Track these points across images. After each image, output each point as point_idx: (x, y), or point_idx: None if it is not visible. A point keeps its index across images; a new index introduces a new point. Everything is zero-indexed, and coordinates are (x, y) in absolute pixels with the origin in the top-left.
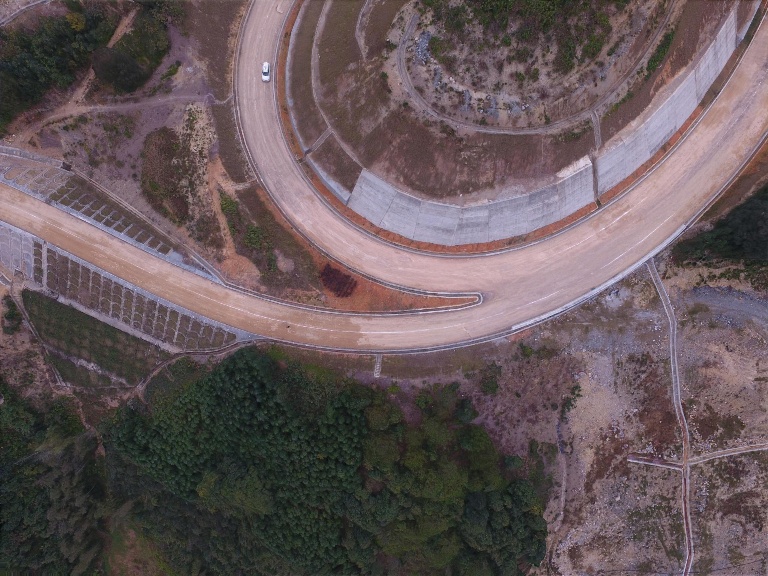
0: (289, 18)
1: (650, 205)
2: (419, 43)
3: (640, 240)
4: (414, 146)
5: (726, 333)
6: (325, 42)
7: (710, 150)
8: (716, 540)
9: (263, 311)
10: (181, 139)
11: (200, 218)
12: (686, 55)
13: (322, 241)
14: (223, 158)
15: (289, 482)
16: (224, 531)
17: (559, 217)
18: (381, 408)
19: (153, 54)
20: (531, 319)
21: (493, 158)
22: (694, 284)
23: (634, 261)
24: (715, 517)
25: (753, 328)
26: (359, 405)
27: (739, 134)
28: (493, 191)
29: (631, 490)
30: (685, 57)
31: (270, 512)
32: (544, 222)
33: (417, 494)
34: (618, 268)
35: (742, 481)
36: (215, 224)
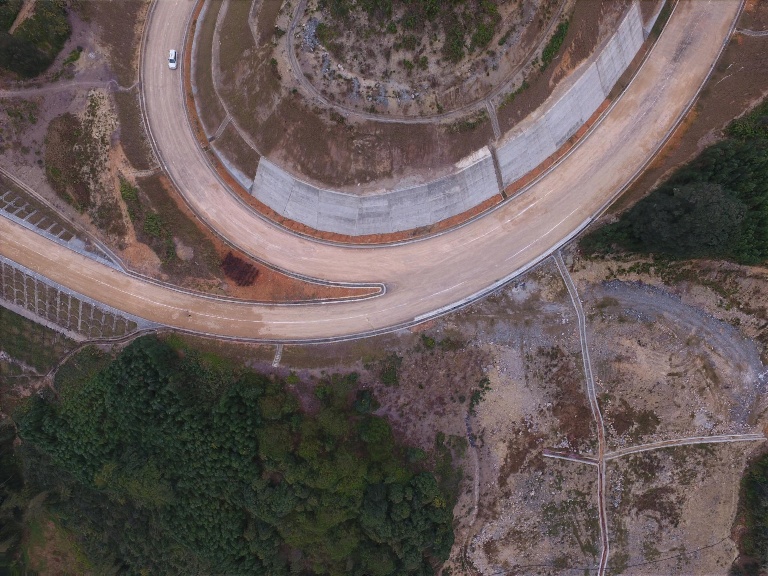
0: (198, 5)
1: (556, 197)
2: (306, 29)
3: (545, 232)
4: (307, 134)
5: (637, 327)
6: (225, 29)
7: (617, 143)
8: (631, 536)
9: (164, 299)
10: (83, 125)
11: (102, 205)
12: (586, 47)
13: (226, 230)
14: (125, 145)
15: (187, 472)
16: (136, 522)
17: (464, 208)
18: (274, 397)
19: (53, 39)
20: (434, 310)
21: (388, 147)
22: (603, 278)
23: (539, 253)
24: (630, 513)
25: (664, 323)
26: (250, 394)
27: (646, 128)
28: (391, 181)
29: (546, 485)
30: (585, 49)
31: (175, 503)
32: (448, 213)
33: (310, 484)
34: (523, 260)
35: (657, 477)
36: (117, 211)
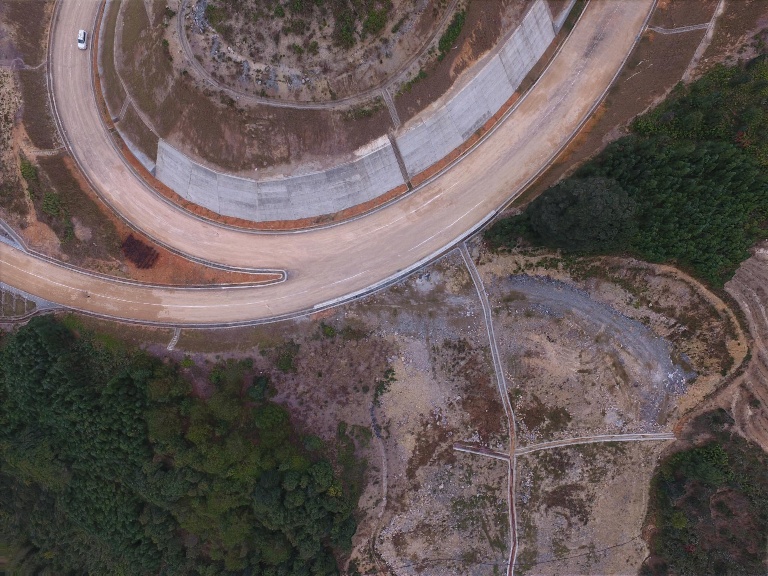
0: None
1: (462, 189)
2: (196, 11)
3: (449, 224)
4: (201, 116)
5: (545, 323)
6: (128, 10)
7: (525, 137)
8: (540, 532)
9: (64, 280)
10: None
11: (4, 183)
12: (488, 38)
13: (128, 212)
14: (27, 123)
15: (79, 453)
16: (42, 504)
17: (368, 197)
18: (162, 380)
19: None
20: (334, 299)
21: (283, 132)
22: (511, 272)
23: (442, 245)
24: (539, 509)
25: (572, 319)
26: (138, 376)
27: (555, 122)
28: (289, 166)
29: (455, 478)
30: (487, 40)
31: (74, 485)
32: (352, 202)
33: (198, 469)
34: (426, 251)
35: (567, 474)
36: (19, 190)
